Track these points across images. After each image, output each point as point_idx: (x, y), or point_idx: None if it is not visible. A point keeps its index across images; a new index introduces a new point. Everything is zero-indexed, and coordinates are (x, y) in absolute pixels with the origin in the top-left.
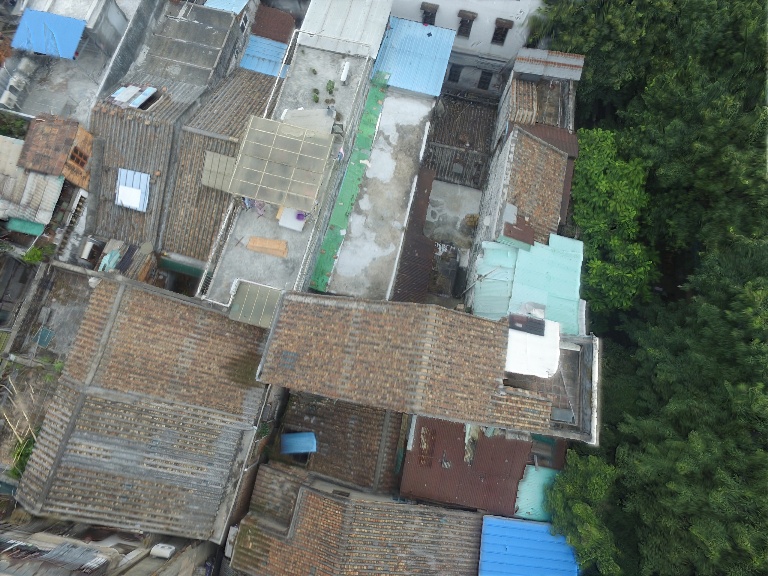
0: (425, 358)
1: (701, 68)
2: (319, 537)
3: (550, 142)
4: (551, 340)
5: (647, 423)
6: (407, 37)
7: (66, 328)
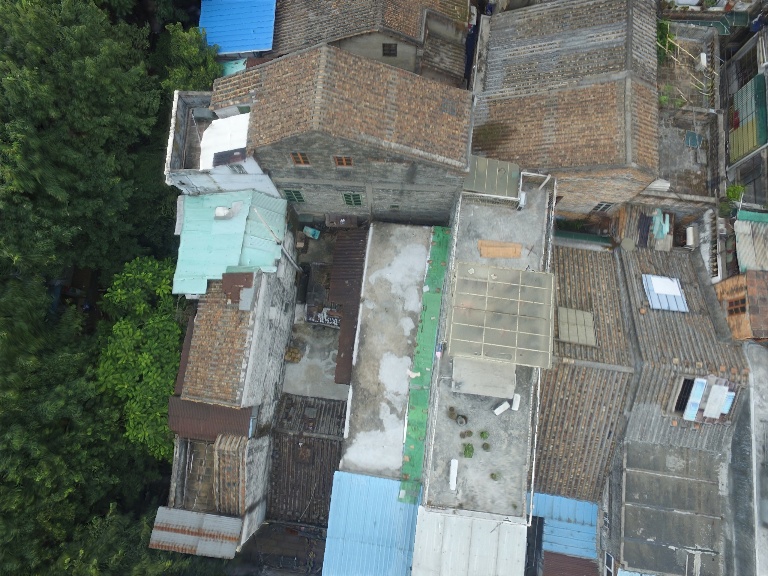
0: (320, 87)
1: (4, 499)
2: (401, 8)
3: (201, 413)
4: (208, 153)
5: (129, 116)
6: (384, 573)
7: (675, 150)
